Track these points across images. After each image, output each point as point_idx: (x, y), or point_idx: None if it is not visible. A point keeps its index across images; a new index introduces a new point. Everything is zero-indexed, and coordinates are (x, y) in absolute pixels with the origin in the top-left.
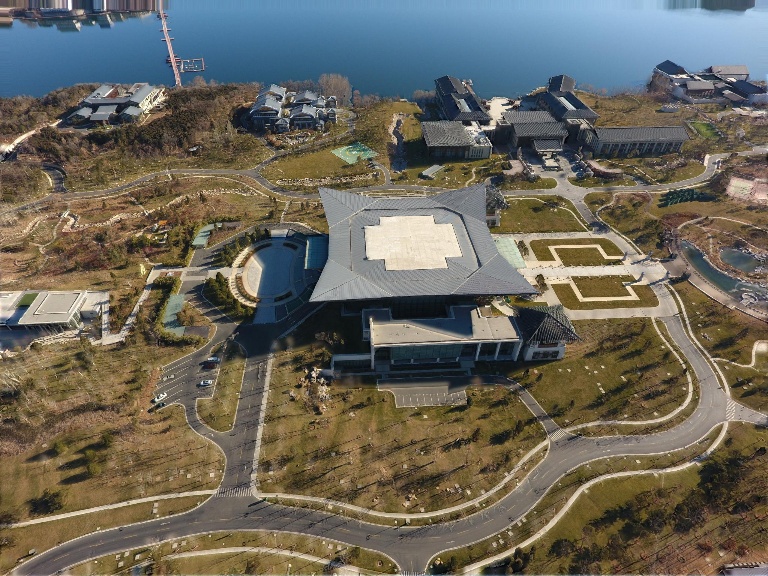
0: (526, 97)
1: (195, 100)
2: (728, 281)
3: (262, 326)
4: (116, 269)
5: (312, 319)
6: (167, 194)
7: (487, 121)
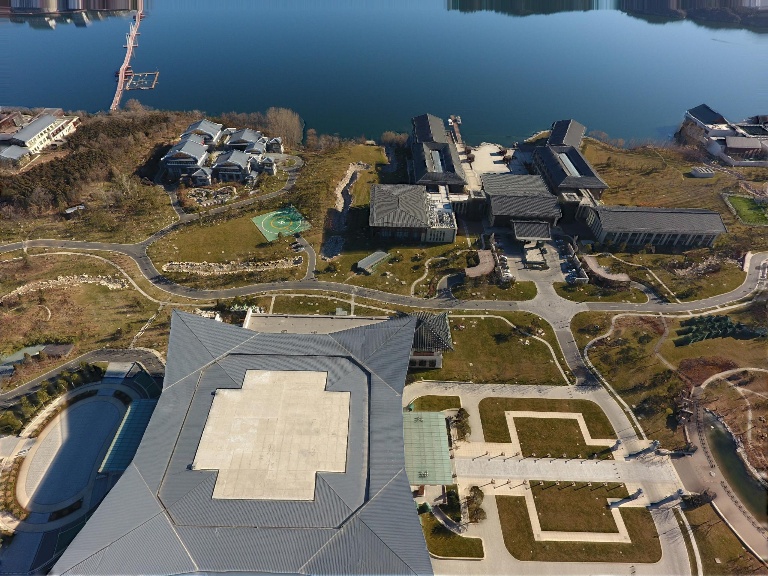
0: (523, 144)
1: (103, 137)
2: None
3: None
4: None
5: None
6: (9, 280)
7: (461, 185)
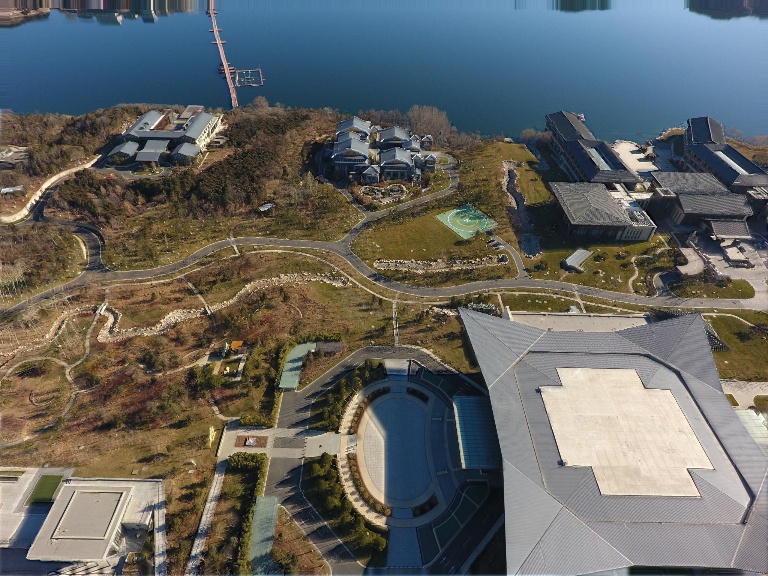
0: (657, 142)
1: (262, 135)
2: None
3: (403, 574)
4: (173, 428)
5: (482, 568)
6: (234, 278)
7: (633, 183)
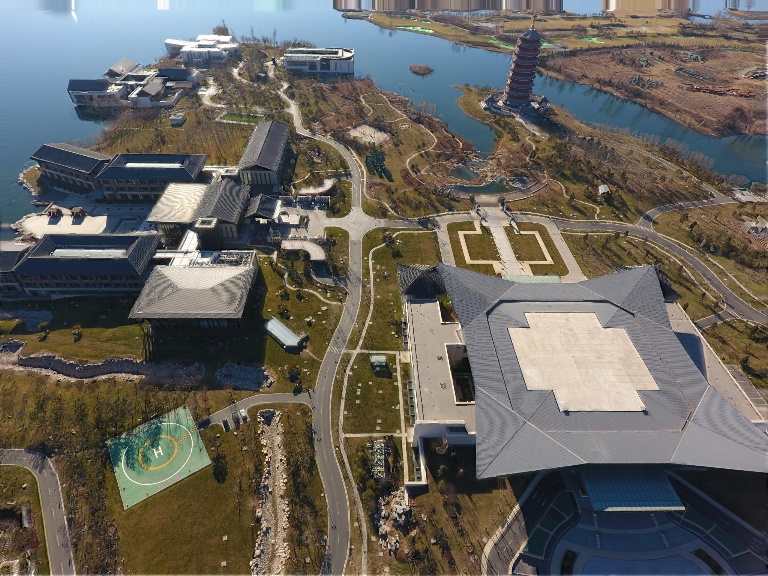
0: (41, 197)
1: None
2: (495, 186)
3: None
4: None
5: None
6: None
7: None
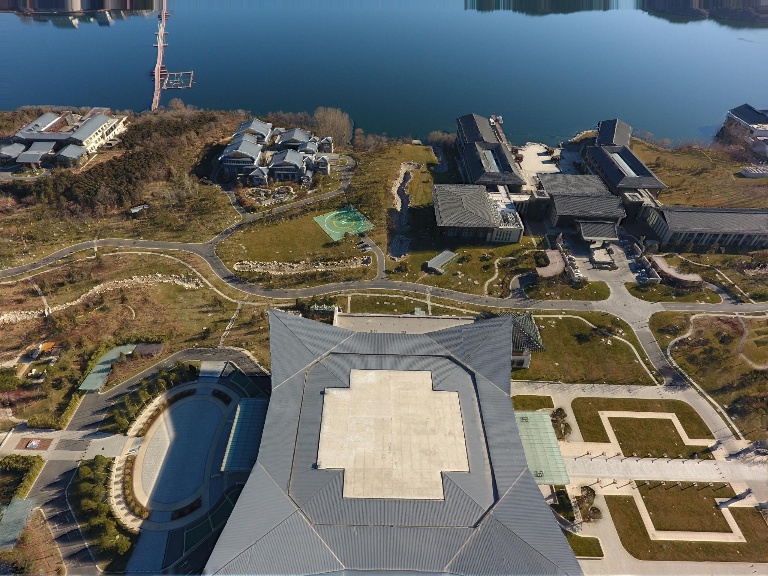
0: (568, 144)
1: (156, 137)
2: None
3: None
4: None
5: None
6: (85, 280)
7: (519, 185)
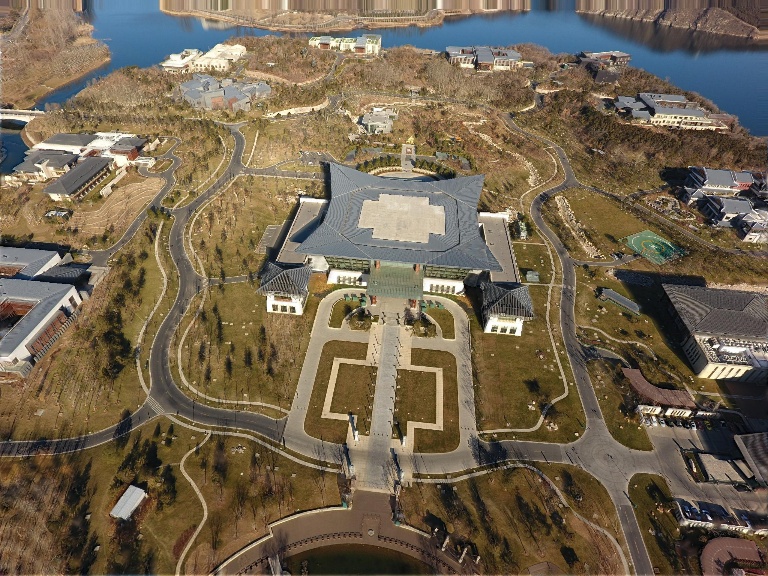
0: None
1: (700, 139)
2: None
3: None
4: (415, 135)
5: None
6: None
7: None
